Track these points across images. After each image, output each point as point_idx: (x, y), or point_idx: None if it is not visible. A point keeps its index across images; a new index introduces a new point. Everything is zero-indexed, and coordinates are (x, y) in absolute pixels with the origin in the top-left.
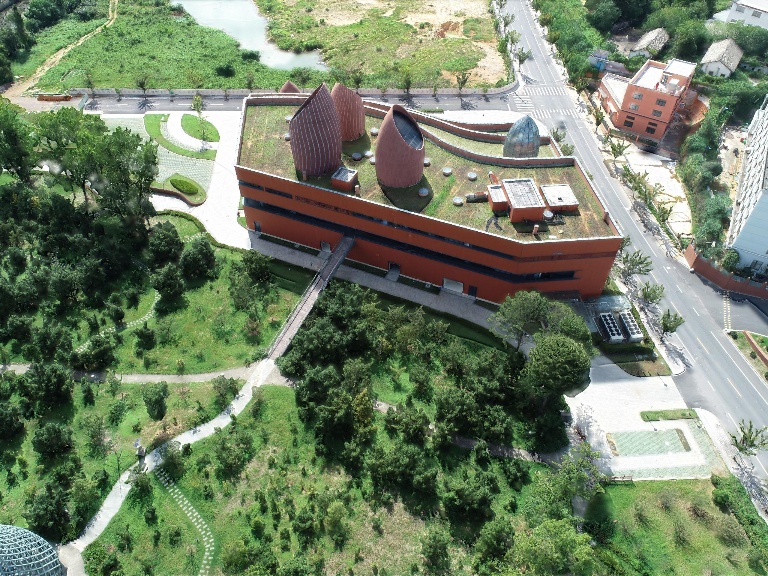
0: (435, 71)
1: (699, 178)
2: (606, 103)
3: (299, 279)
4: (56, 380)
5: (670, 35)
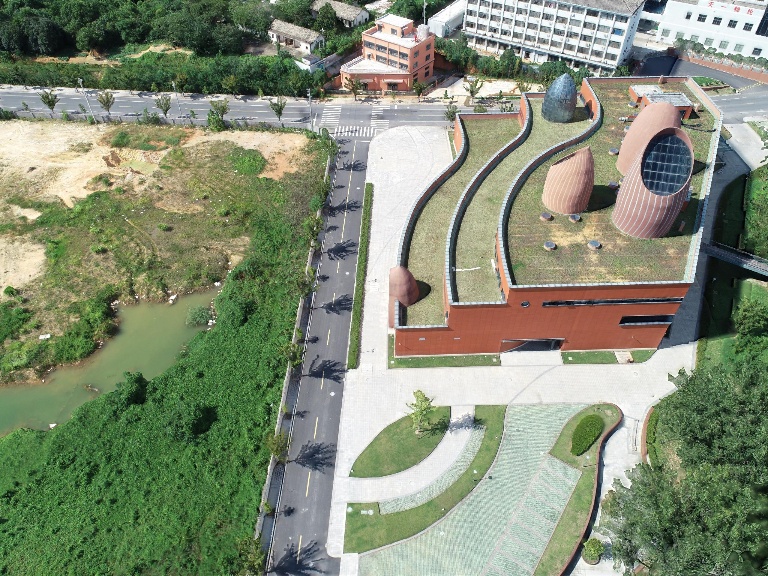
0: (265, 181)
1: (518, 64)
2: (376, 85)
3: (725, 297)
4: None
5: (285, 21)
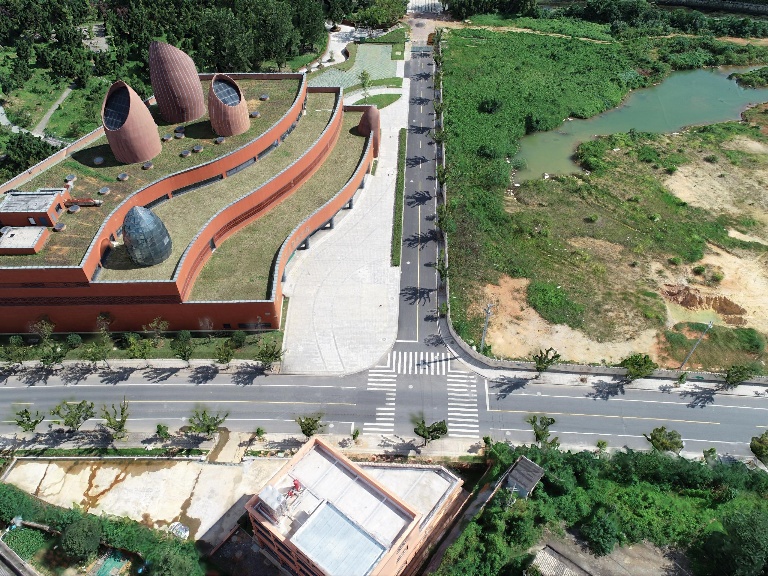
0: None
1: None
2: None
3: None
4: (53, 60)
5: None
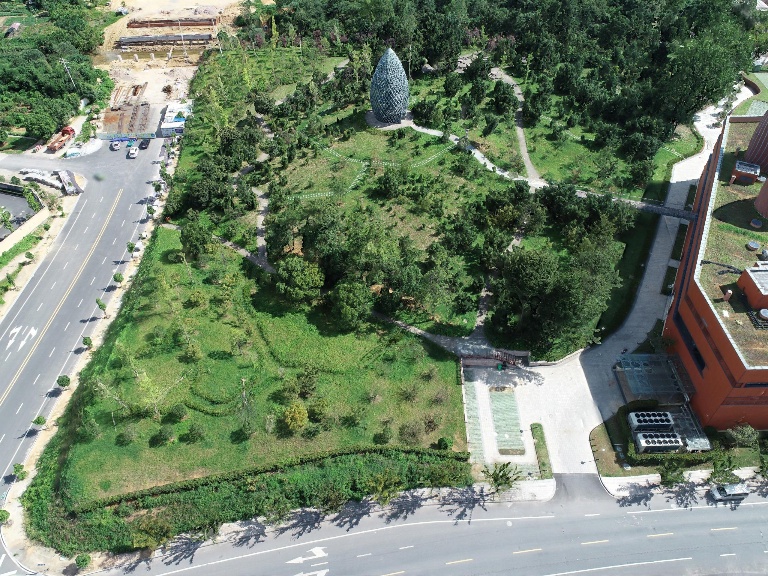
0: None
1: None
2: None
3: None
4: (503, 97)
5: None
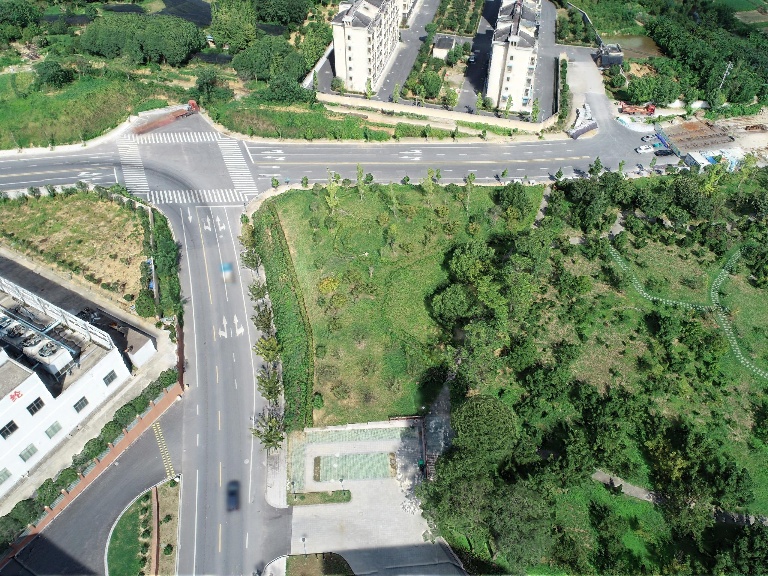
0: None
1: None
2: None
3: None
4: None
5: None
